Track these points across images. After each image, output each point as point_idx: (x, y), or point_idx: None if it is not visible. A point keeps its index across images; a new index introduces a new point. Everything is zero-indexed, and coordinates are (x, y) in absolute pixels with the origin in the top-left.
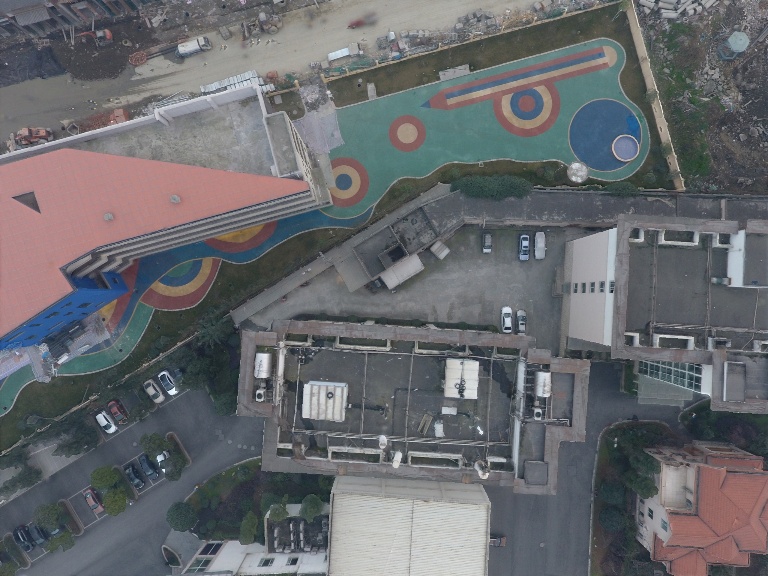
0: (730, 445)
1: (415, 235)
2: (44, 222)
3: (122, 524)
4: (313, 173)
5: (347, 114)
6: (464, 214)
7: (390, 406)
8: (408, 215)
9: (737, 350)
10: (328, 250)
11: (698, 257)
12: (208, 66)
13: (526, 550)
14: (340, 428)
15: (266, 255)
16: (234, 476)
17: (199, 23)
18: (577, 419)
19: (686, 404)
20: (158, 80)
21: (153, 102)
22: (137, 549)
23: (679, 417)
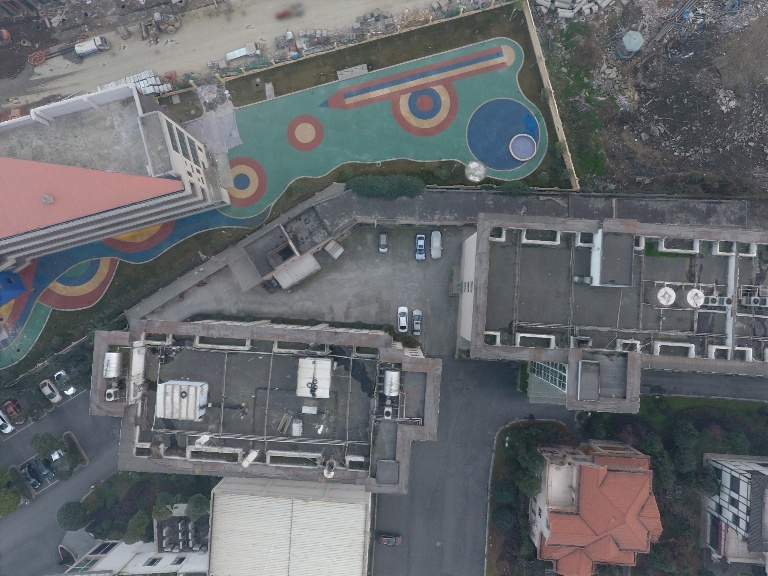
0: (626, 444)
1: (308, 235)
2: None
3: (19, 524)
4: (206, 173)
5: (245, 114)
6: (356, 213)
7: (250, 405)
8: (301, 215)
9: (599, 349)
10: (223, 250)
11: (562, 256)
12: (107, 66)
13: (422, 549)
14: (201, 427)
15: (163, 255)
16: (131, 476)
17: (99, 23)
18: (429, 418)
19: None
20: (57, 80)
21: (52, 102)
22: (34, 549)
23: (576, 416)
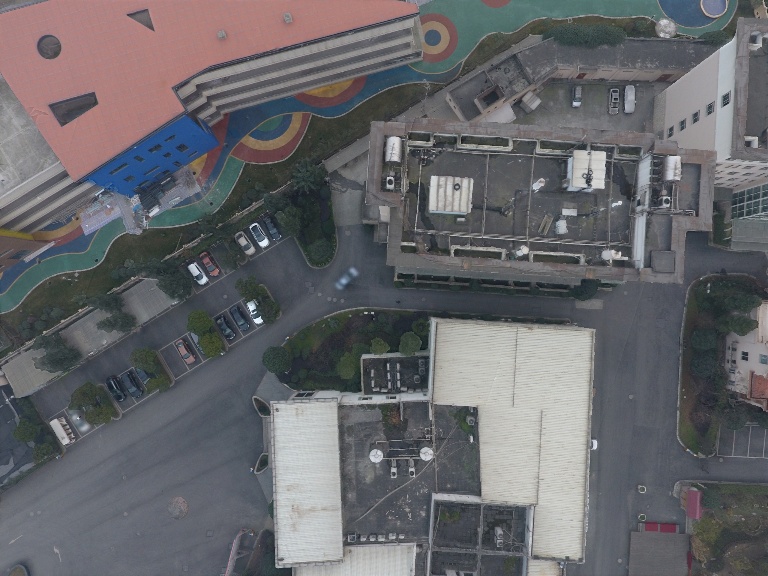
0: None
1: (508, 84)
2: (158, 40)
3: (213, 375)
4: None
5: None
6: (558, 62)
7: None
8: (501, 64)
9: None
10: (420, 101)
11: None
12: None
13: (615, 402)
14: (461, 229)
15: (356, 109)
16: (324, 328)
17: None
18: (704, 209)
19: None
20: None
21: None
22: (228, 400)
23: (767, 271)
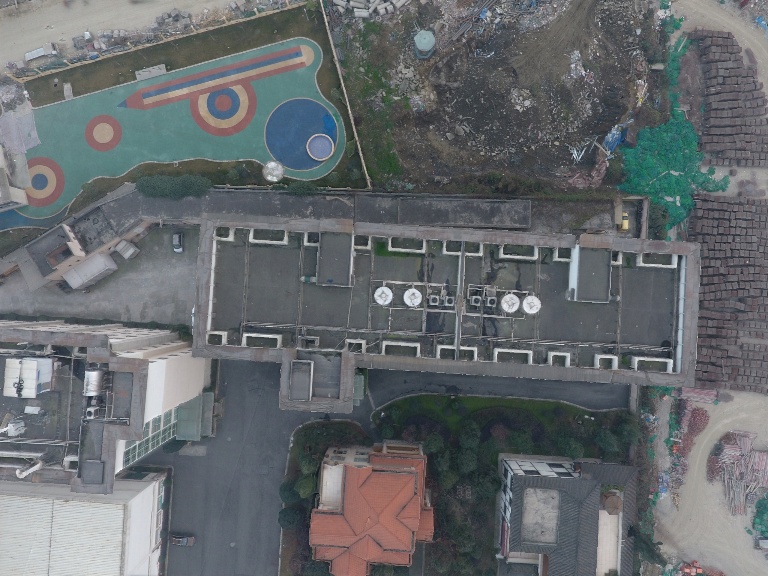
0: (419, 444)
1: (96, 235)
2: None
3: None
4: None
5: (44, 114)
6: (142, 214)
7: None
8: (89, 215)
9: (326, 349)
10: (14, 250)
11: (293, 256)
12: None
13: (216, 550)
14: None
15: None
16: None
17: None
18: (135, 418)
19: (378, 403)
20: None
21: None
22: None
23: (371, 416)
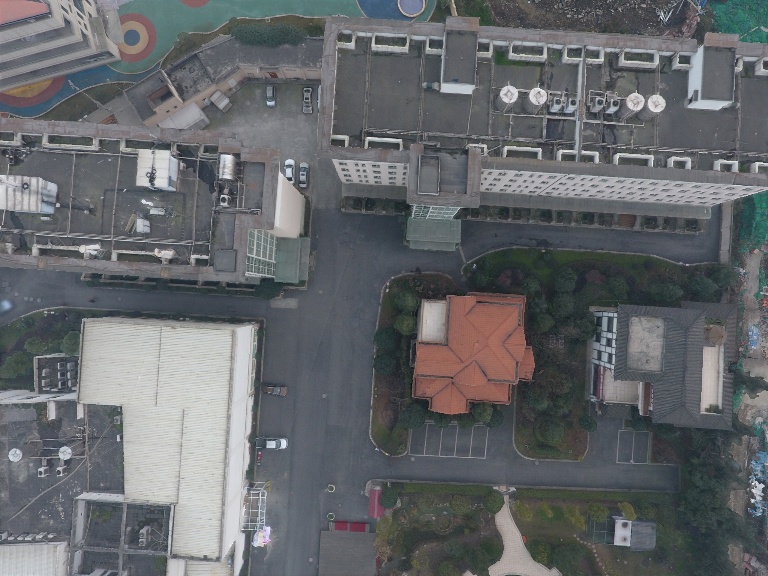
0: None
1: (192, 83)
2: None
3: None
4: (91, 22)
5: None
6: (239, 61)
7: (99, 207)
8: (185, 63)
9: None
10: (109, 101)
11: (413, 64)
12: None
13: (308, 401)
14: (50, 228)
15: (54, 109)
16: (19, 327)
17: None
18: (266, 207)
19: (469, 257)
20: None
21: None
22: None
23: (462, 269)
